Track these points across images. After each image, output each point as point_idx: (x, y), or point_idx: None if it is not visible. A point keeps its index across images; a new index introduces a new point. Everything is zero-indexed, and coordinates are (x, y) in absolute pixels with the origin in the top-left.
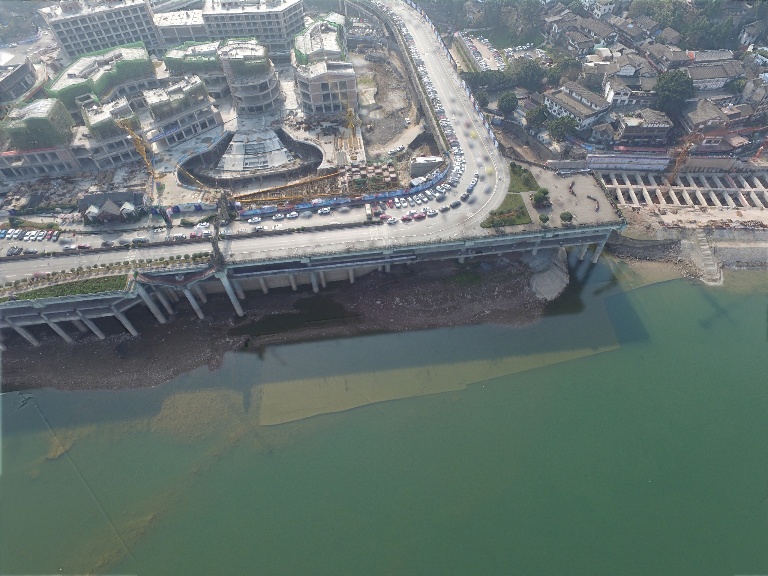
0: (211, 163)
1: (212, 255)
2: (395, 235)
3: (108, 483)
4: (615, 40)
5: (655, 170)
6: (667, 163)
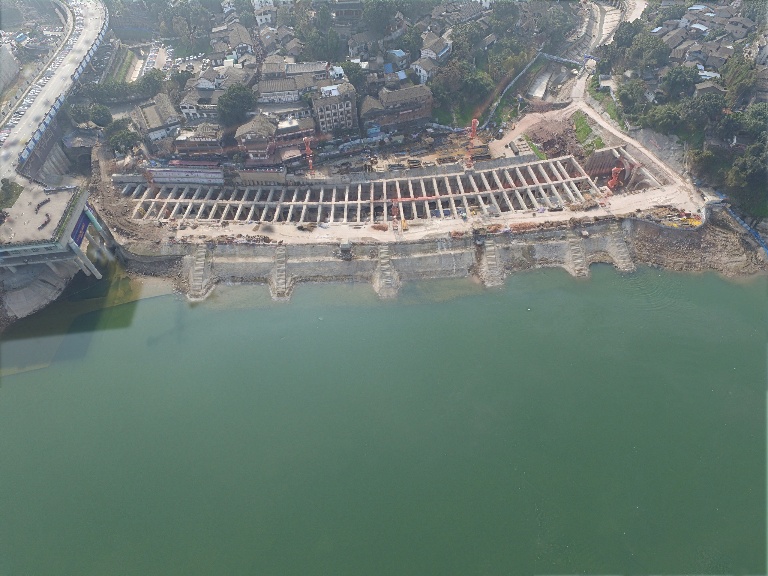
0: None
1: None
2: None
3: None
4: (250, 51)
5: (217, 183)
6: (222, 177)
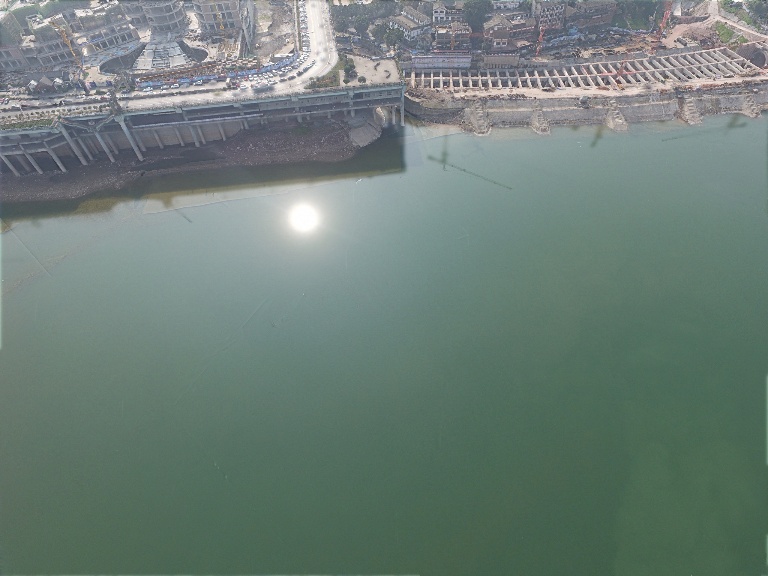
0: (128, 65)
1: (109, 101)
2: (243, 95)
3: (37, 243)
4: None
5: (464, 68)
6: (470, 61)
